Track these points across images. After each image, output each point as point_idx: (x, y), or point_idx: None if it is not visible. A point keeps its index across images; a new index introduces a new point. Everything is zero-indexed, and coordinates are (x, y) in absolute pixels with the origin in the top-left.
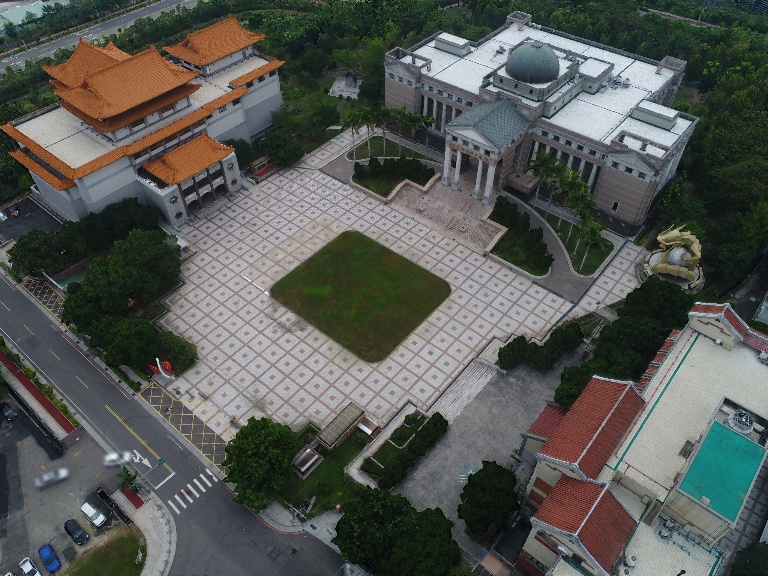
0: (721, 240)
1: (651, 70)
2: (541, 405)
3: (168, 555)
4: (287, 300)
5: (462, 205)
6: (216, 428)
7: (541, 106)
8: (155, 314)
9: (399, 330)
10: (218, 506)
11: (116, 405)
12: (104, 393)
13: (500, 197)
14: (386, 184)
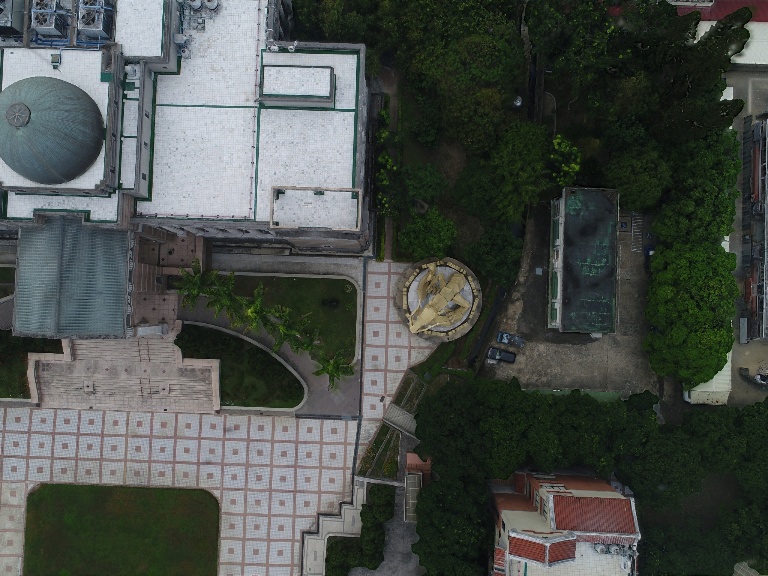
0: (476, 214)
1: None
2: None
3: None
4: None
5: (135, 352)
6: None
7: (122, 204)
8: None
9: None
10: None
11: None
12: None
13: (178, 345)
14: (10, 374)
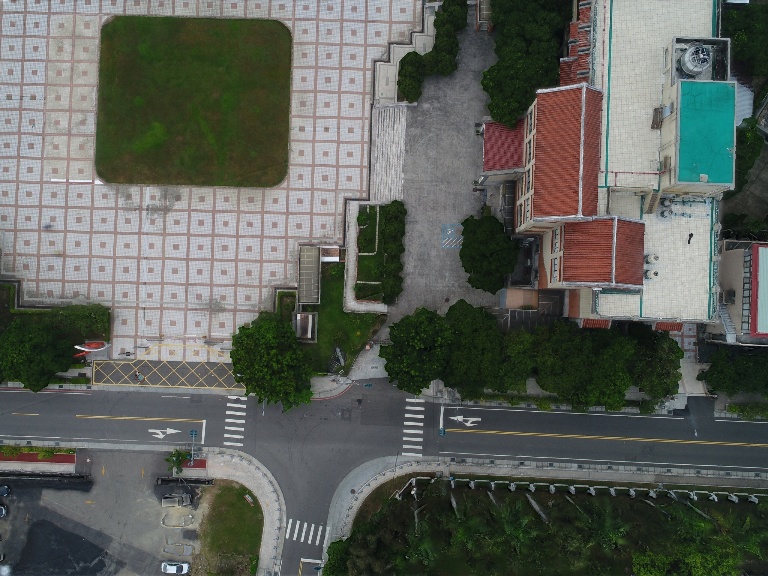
0: None
1: None
2: (469, 116)
3: (266, 477)
4: (128, 175)
5: None
6: (198, 358)
7: None
8: (10, 298)
9: (275, 125)
10: (268, 416)
11: (85, 409)
12: (60, 407)
13: None
14: None
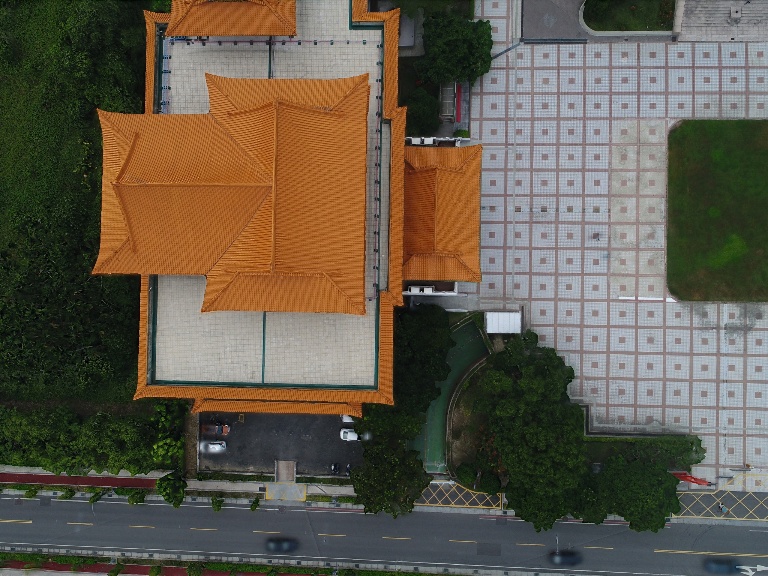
0: None
1: None
2: None
3: None
4: (705, 292)
5: None
6: None
7: None
8: None
9: None
10: None
11: (665, 543)
12: (637, 541)
13: None
14: (650, 3)
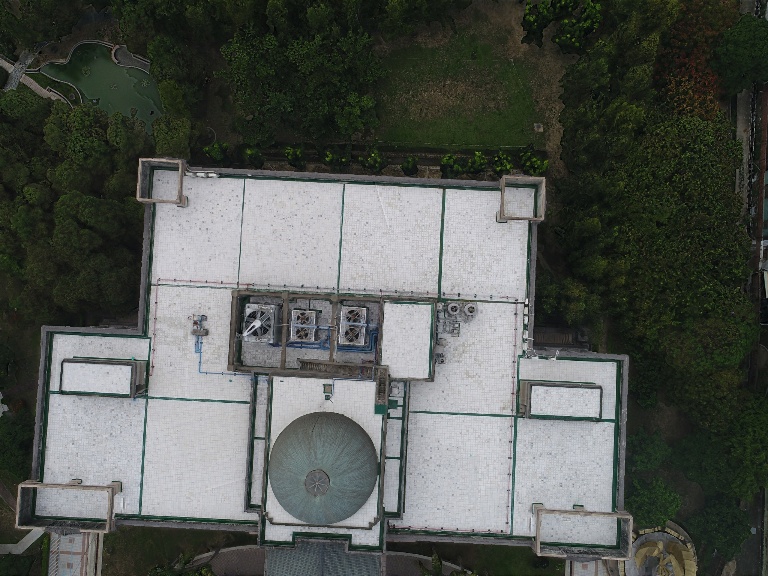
0: None
1: (485, 215)
2: None
3: None
4: None
5: None
6: None
7: None
8: None
9: None
10: None
11: None
12: None
13: None
14: None
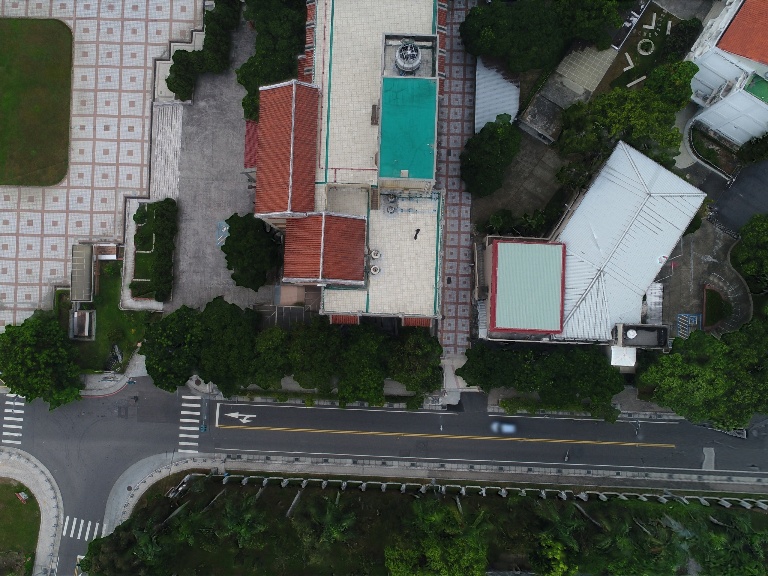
0: None
1: None
2: None
3: (44, 475)
4: None
5: None
6: None
7: None
8: None
9: (55, 124)
10: (46, 414)
11: None
12: None
13: None
14: None
